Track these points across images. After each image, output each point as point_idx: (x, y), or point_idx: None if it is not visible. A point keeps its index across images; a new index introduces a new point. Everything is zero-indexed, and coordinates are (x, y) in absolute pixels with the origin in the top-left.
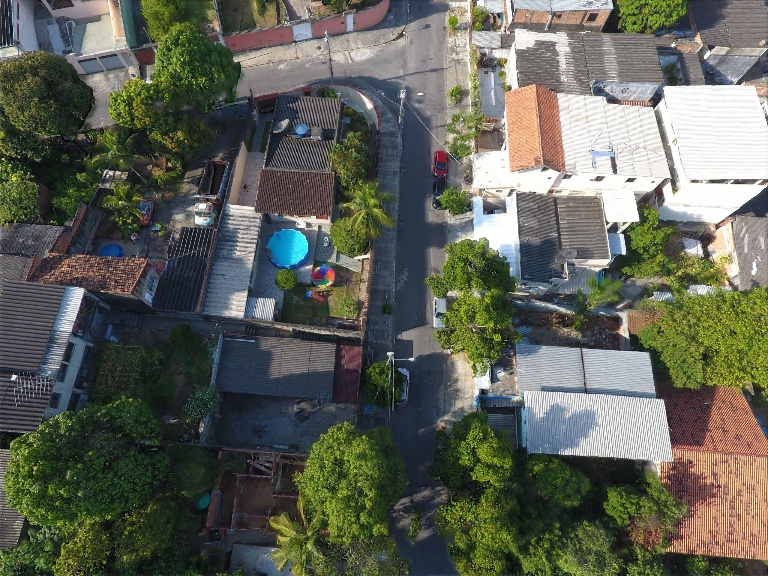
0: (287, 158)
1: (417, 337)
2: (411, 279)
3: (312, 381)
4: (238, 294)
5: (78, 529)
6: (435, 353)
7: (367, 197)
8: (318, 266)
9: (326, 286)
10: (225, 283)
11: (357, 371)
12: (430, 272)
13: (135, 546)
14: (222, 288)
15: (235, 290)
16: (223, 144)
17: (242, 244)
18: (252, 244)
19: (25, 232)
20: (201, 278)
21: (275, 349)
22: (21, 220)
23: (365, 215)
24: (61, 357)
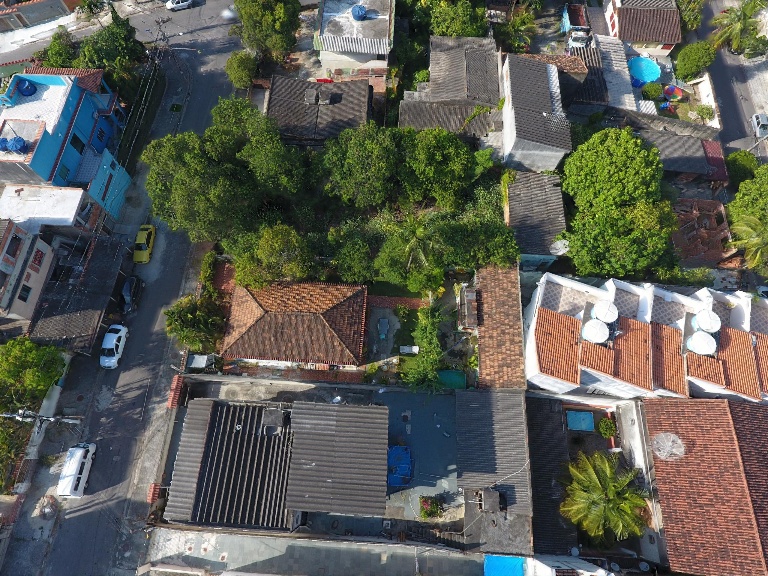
0: (635, 0)
1: (743, 145)
2: (726, 105)
3: (692, 162)
4: (627, 95)
5: (624, 212)
6: (761, 156)
7: (748, 8)
8: (663, 87)
9: (677, 99)
10: (615, 87)
11: (721, 158)
12: (740, 100)
13: (669, 222)
14: (613, 91)
15: (623, 93)
16: (550, 3)
17: (616, 62)
18: (624, 62)
19: (466, 41)
20: (603, 80)
21: (657, 139)
22: (458, 34)
23: (741, 25)
24: (561, 108)
